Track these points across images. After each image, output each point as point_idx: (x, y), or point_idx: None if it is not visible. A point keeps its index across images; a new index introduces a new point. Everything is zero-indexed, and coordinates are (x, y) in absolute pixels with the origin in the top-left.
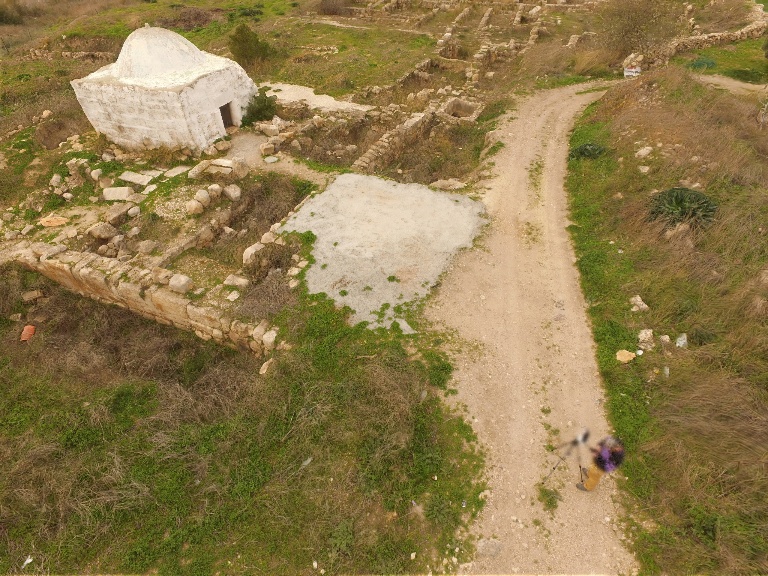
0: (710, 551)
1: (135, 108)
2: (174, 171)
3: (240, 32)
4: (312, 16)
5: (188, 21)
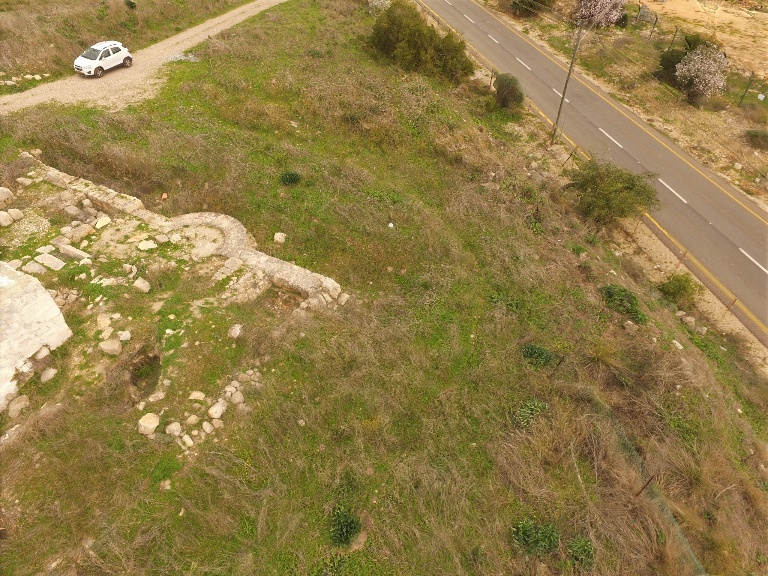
0: None
1: None
2: None
3: None
4: None
5: None
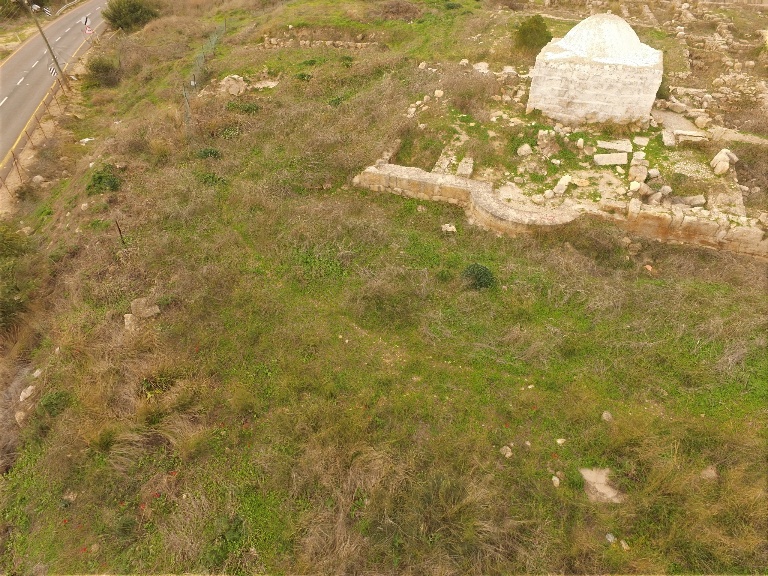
0: None
1: (605, 85)
2: (640, 141)
3: (535, 22)
4: (507, 10)
5: (396, 13)
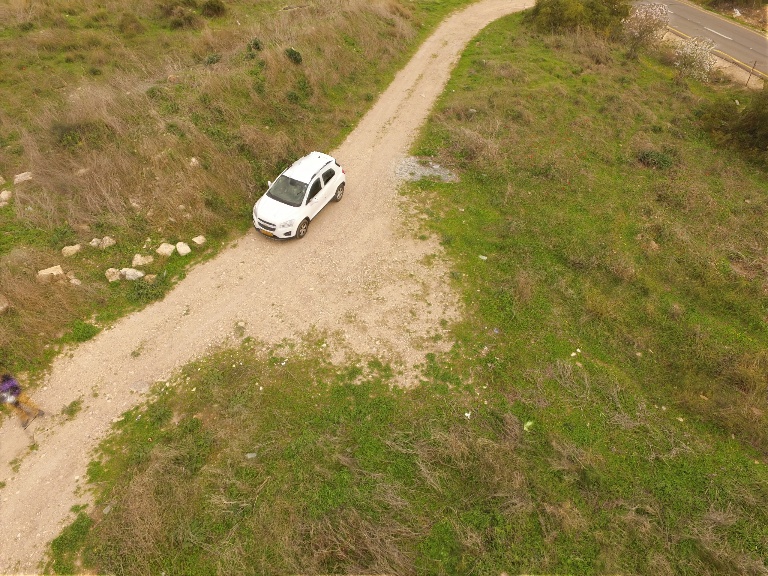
0: (6, 347)
1: None
2: None
3: None
4: None
5: None
